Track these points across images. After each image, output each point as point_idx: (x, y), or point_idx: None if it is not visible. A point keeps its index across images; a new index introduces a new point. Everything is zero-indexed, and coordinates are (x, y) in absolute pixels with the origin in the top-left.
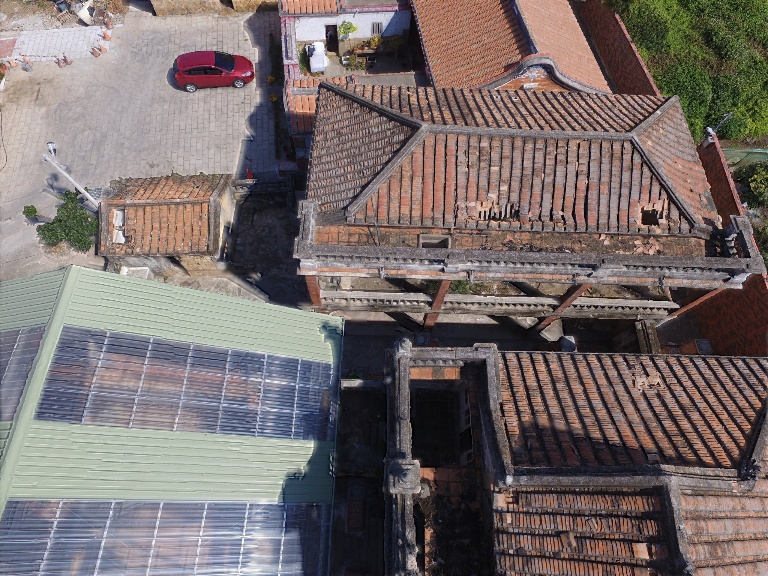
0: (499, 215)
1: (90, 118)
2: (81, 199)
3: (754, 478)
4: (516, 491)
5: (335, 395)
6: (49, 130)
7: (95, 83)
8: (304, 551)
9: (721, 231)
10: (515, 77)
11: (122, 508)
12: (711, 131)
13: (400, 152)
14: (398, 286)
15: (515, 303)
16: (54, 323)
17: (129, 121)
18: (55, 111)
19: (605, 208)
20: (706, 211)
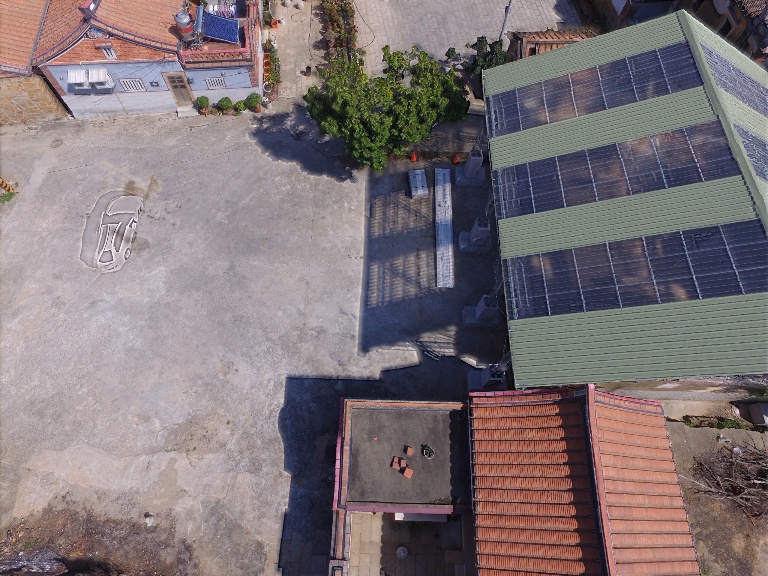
0: None
1: (427, 6)
2: None
3: None
4: None
5: None
6: (398, 14)
7: None
8: None
9: None
10: None
11: None
12: None
13: None
14: None
15: None
16: (695, 37)
17: (460, 8)
18: (397, 0)
19: None
20: None
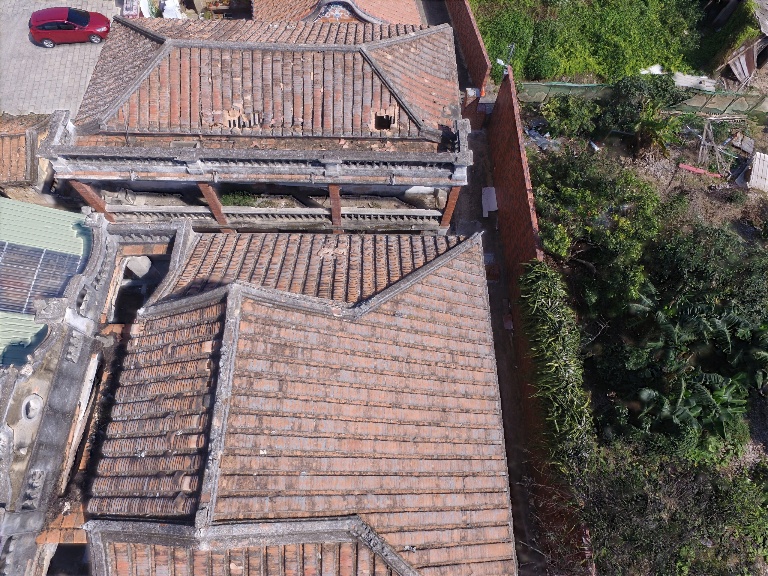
0: (249, 124)
1: None
2: None
3: (360, 307)
4: None
5: None
6: None
7: None
8: None
9: (452, 135)
10: (320, 16)
11: None
12: (501, 63)
13: (146, 65)
14: (191, 204)
15: (290, 214)
16: None
17: None
18: None
19: (339, 114)
20: (446, 120)
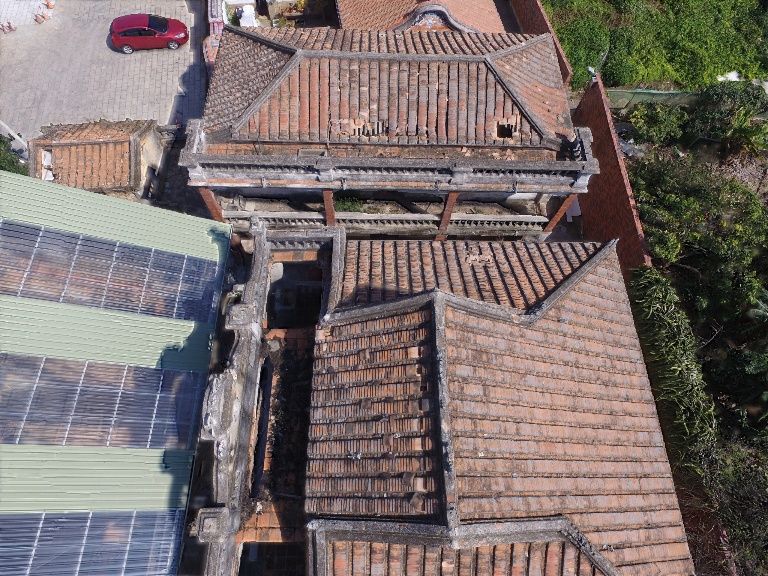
0: (372, 133)
1: (32, 78)
2: (21, 150)
3: (535, 313)
4: (333, 326)
5: (219, 287)
6: None
7: (38, 47)
8: (178, 407)
9: (571, 143)
10: (413, 24)
11: (7, 358)
12: (592, 70)
13: (278, 75)
14: (299, 210)
15: (400, 220)
16: None
17: (69, 80)
18: None
19: (463, 123)
20: (561, 128)
